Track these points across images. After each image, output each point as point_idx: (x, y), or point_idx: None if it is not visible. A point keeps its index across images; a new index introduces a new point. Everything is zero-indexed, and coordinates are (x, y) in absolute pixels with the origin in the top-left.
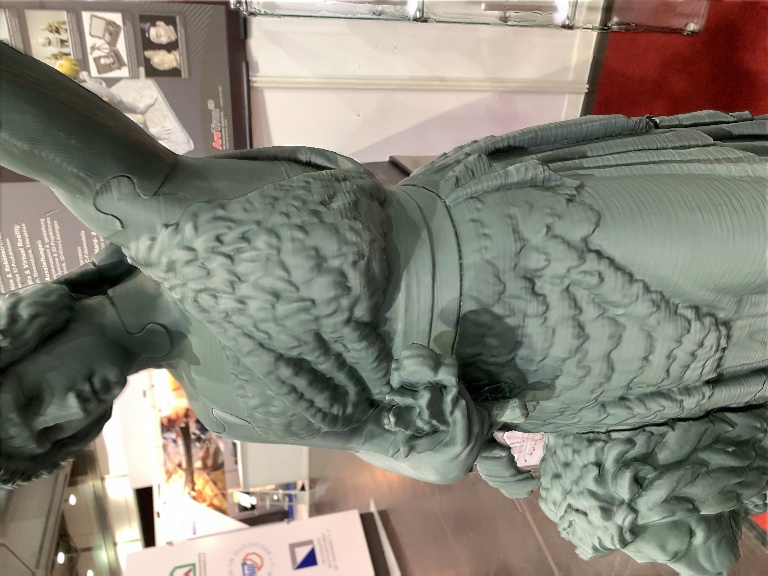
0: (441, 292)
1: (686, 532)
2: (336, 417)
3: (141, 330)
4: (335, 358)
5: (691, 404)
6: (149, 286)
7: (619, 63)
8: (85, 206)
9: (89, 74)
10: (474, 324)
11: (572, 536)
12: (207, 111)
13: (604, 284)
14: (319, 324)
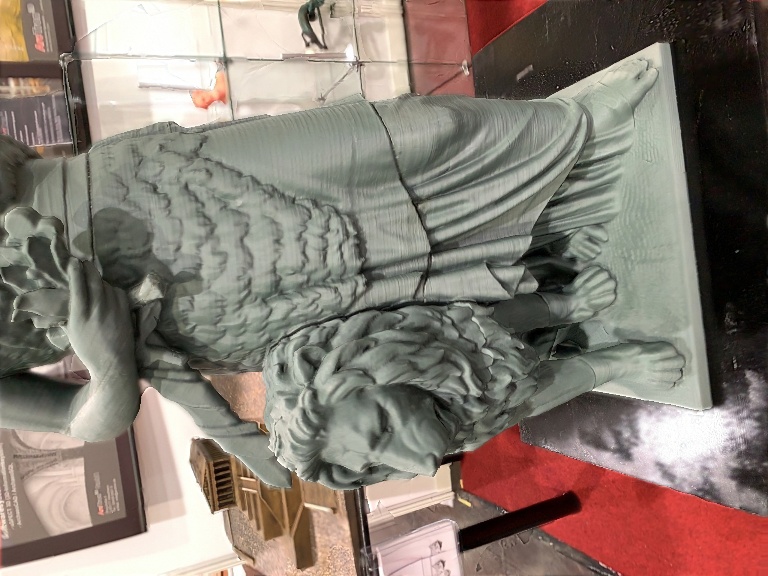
0: (72, 200)
1: (374, 408)
2: None
3: None
4: None
5: (346, 290)
6: None
7: None
8: None
9: None
10: (104, 221)
11: (283, 454)
12: None
13: (214, 178)
14: None
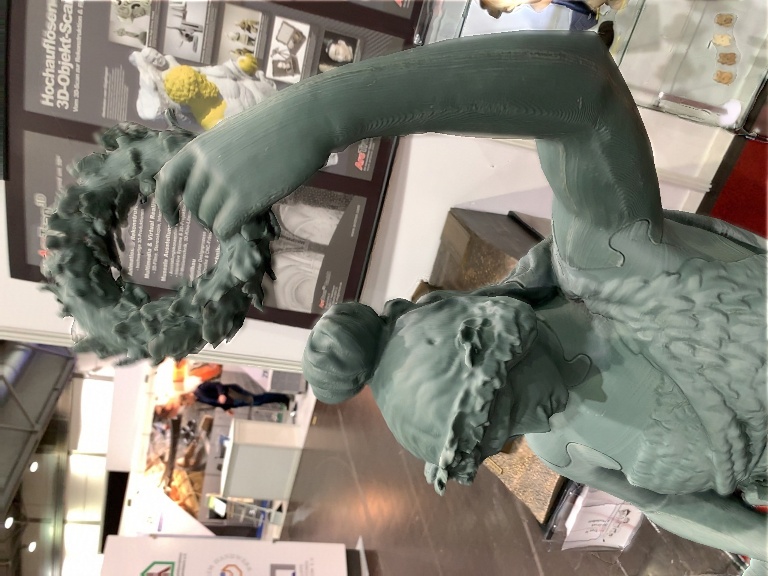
0: None
1: None
2: (735, 482)
3: (572, 358)
4: None
5: None
6: (578, 318)
7: (753, 172)
8: (599, 239)
9: (264, 74)
10: None
11: None
12: None
13: None
14: None
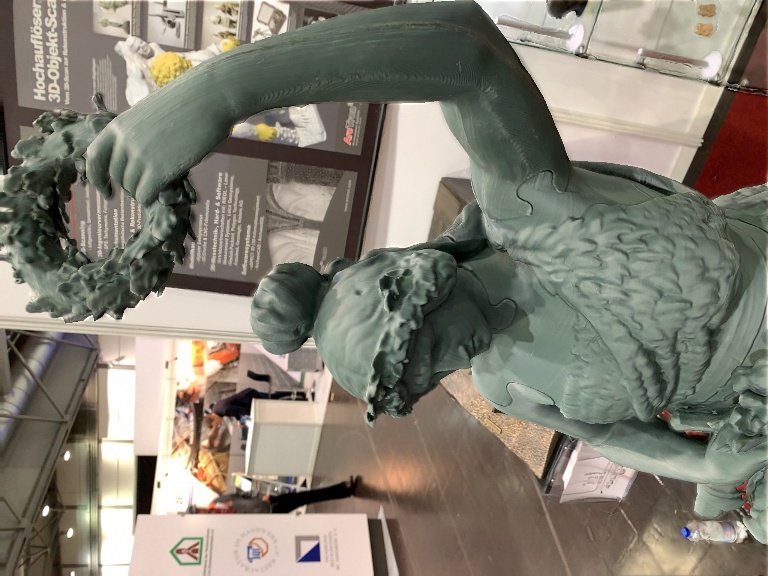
0: None
1: None
2: (652, 408)
3: (498, 303)
4: (676, 356)
5: None
6: (504, 266)
7: (743, 124)
8: (508, 191)
9: None
10: None
11: None
12: (346, 107)
13: None
14: (685, 324)
